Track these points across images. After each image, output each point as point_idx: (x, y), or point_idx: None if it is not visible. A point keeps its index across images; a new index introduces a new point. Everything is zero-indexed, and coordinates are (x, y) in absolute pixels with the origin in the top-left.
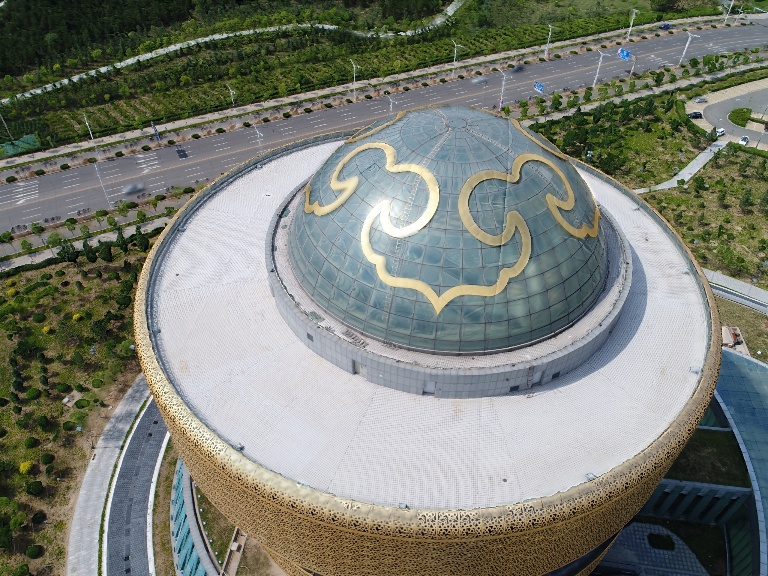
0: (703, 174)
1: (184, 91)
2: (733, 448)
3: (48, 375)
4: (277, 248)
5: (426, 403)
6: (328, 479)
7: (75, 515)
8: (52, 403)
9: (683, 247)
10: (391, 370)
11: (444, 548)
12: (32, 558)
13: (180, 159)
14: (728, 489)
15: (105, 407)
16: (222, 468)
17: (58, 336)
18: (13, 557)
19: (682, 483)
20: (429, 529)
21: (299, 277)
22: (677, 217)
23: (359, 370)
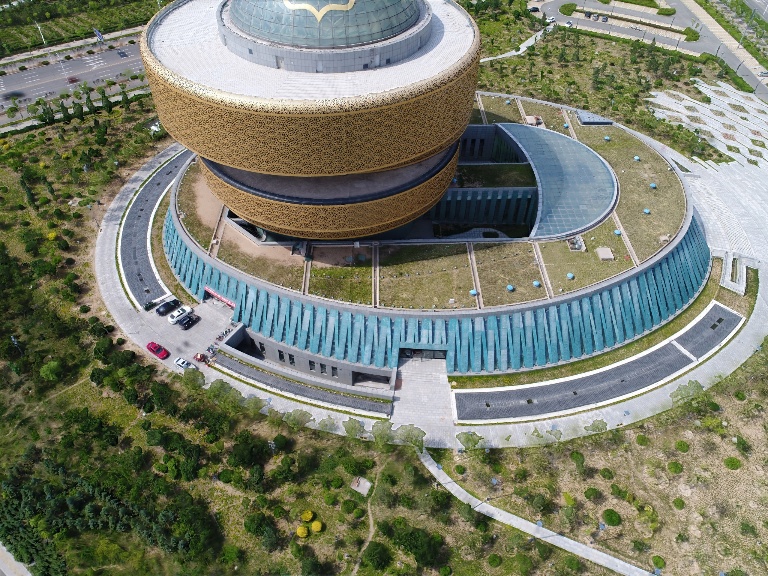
0: (536, 46)
1: (114, 10)
2: (529, 171)
3: None
4: (224, 19)
5: (318, 75)
6: None
7: (96, 259)
8: (60, 205)
9: (466, 13)
10: (297, 56)
11: (331, 122)
12: None
13: (122, 58)
14: (523, 188)
15: (101, 205)
16: (212, 99)
17: (53, 169)
18: (58, 281)
19: (496, 188)
20: (321, 107)
21: (240, 26)
22: (513, 70)
23: (280, 65)
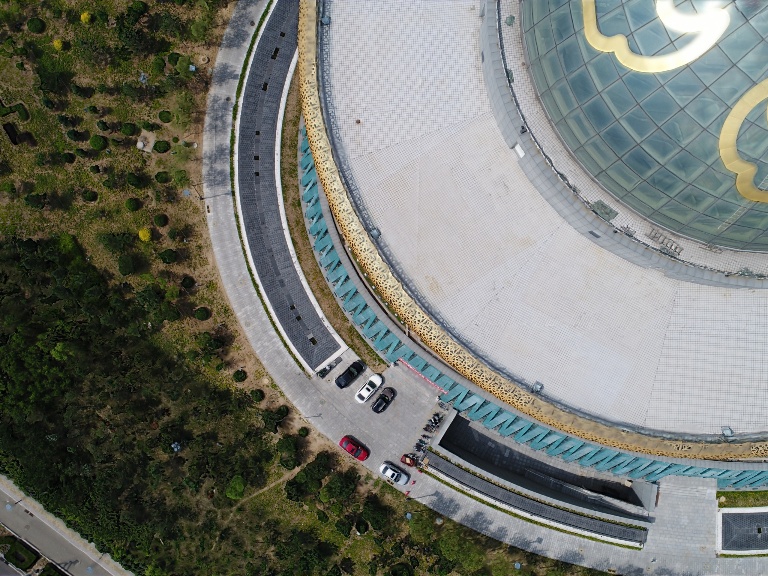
0: None
1: None
2: None
3: (99, 113)
4: (513, 75)
5: (739, 298)
6: (643, 410)
7: (221, 274)
8: (126, 151)
9: None
10: None
11: None
12: (203, 320)
13: None
14: None
15: (189, 146)
16: None
17: (77, 51)
18: (185, 322)
19: None
20: None
21: (568, 141)
22: None
23: None
